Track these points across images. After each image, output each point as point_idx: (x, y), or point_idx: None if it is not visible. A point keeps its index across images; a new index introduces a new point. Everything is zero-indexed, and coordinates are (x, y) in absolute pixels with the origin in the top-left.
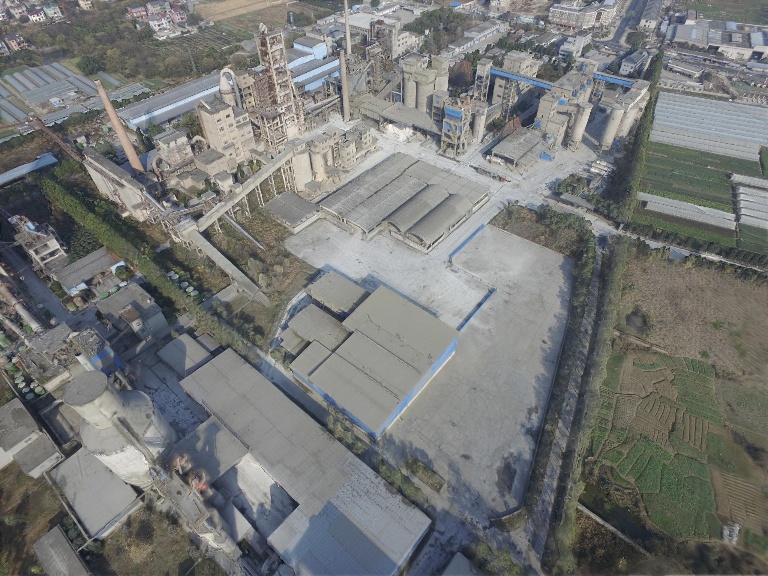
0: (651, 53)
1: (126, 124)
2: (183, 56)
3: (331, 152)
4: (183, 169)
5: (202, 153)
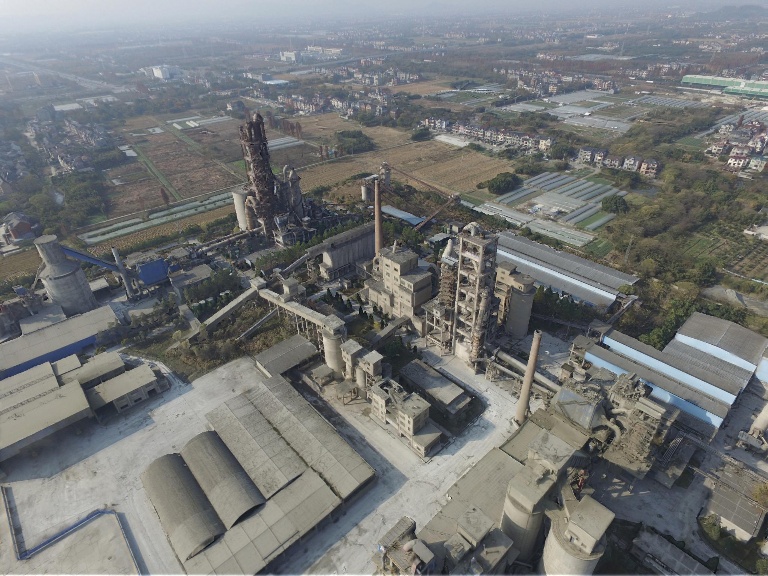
0: None
1: None
2: (700, 254)
3: (363, 375)
4: None
5: None
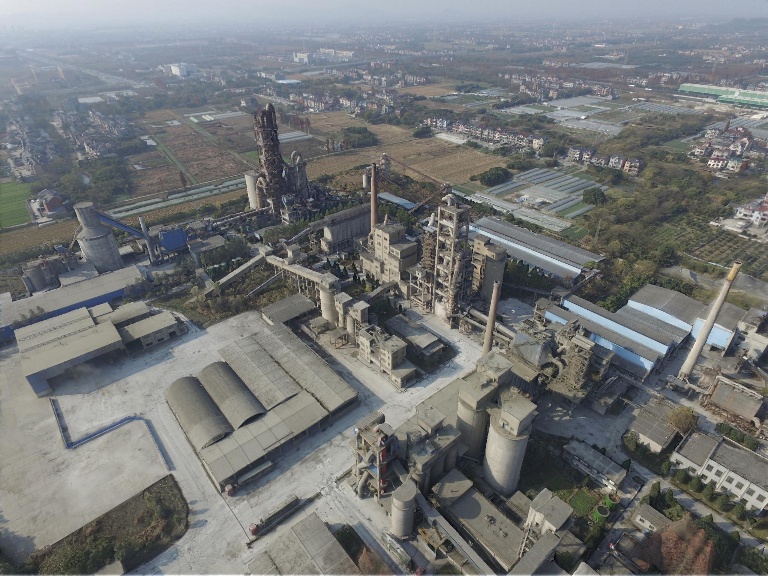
0: None
1: None
2: (666, 240)
3: (352, 322)
4: None
5: None
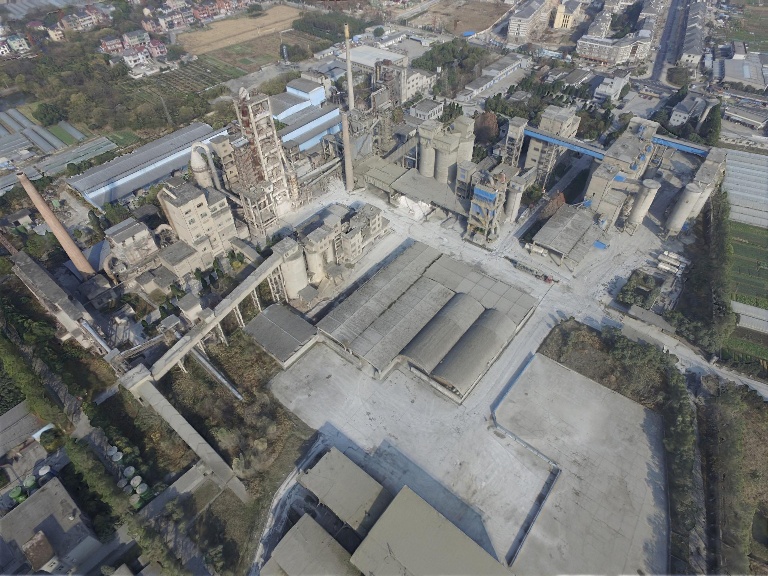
0: (711, 103)
1: (82, 196)
2: (160, 100)
3: (331, 247)
4: (145, 267)
5: (168, 247)
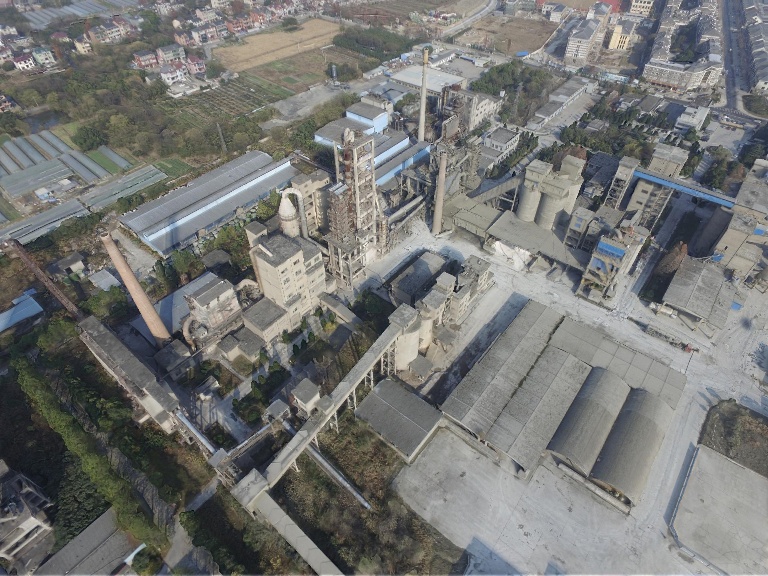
0: None
1: (138, 237)
2: (205, 122)
3: None
4: (225, 328)
5: (254, 307)
